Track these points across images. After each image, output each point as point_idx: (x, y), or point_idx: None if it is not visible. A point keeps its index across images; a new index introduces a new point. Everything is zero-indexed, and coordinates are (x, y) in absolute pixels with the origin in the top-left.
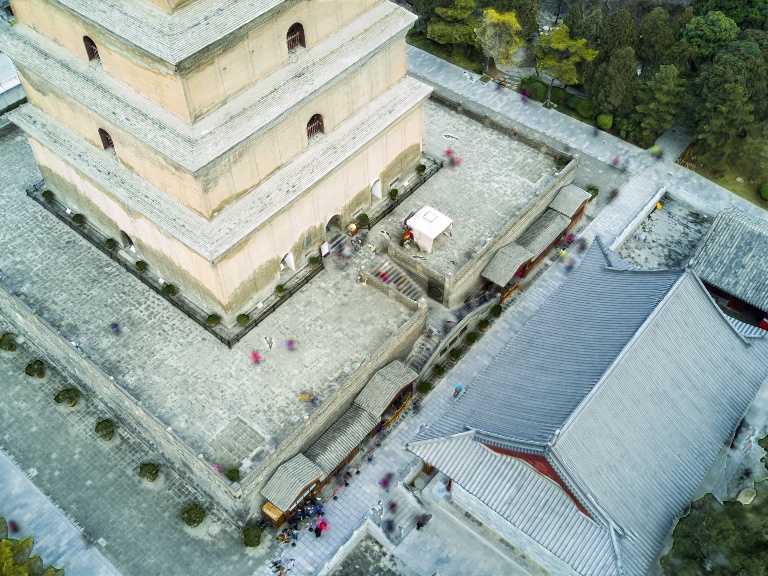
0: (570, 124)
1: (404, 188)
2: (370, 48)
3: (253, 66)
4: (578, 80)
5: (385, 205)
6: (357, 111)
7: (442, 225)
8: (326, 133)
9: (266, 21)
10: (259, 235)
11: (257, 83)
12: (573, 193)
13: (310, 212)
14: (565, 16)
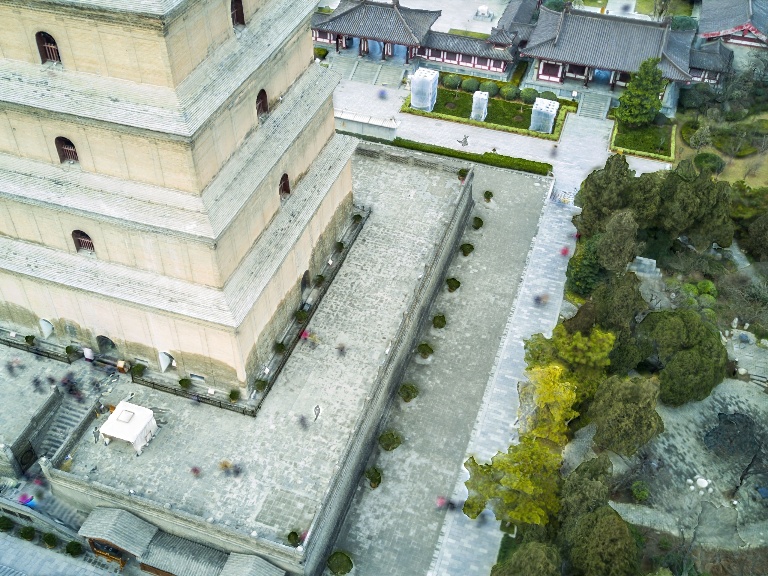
0: (478, 563)
1: (206, 392)
2: (137, 218)
3: (18, 142)
4: (524, 531)
5: (174, 384)
6: (144, 269)
7: (120, 432)
8: (100, 258)
9: (24, 112)
10: (8, 277)
11: (23, 158)
12: (254, 572)
13: (70, 307)
14: (765, 503)
